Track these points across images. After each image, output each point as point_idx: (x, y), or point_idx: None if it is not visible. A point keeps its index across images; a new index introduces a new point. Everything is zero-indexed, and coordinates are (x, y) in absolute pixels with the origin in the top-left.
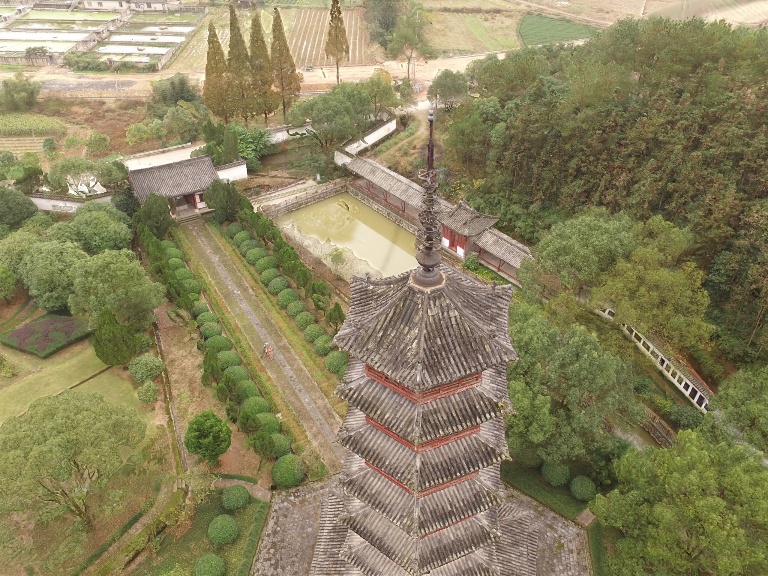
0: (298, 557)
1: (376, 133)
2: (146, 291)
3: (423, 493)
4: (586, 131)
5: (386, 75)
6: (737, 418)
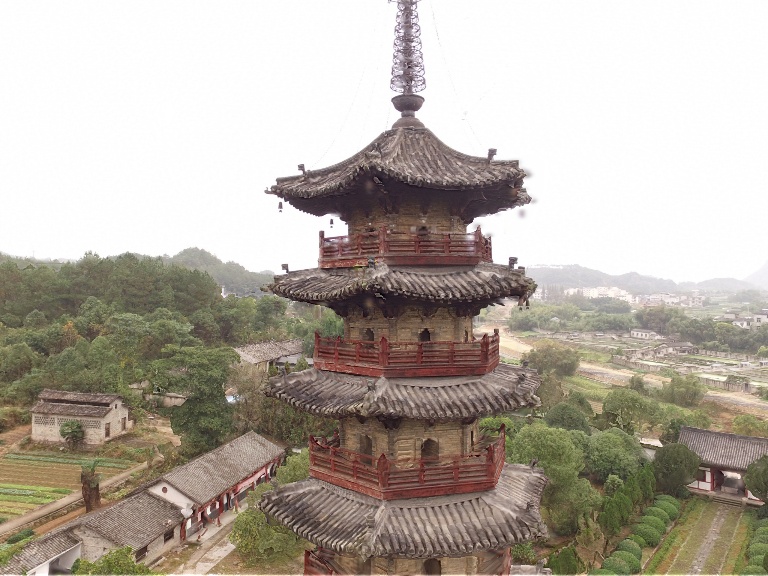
0: None
1: None
2: (563, 473)
3: (315, 467)
4: None
5: None
6: None
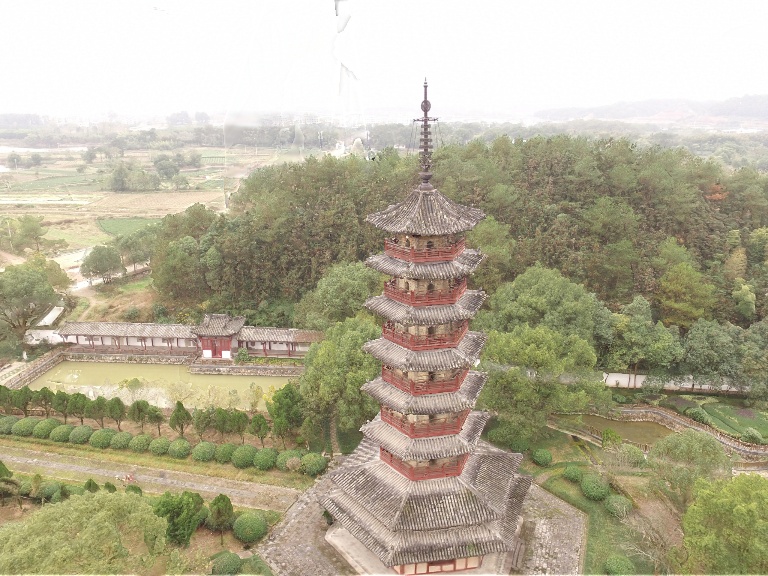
0: (320, 567)
1: (52, 312)
2: None
3: None
4: (282, 235)
5: (43, 257)
6: (500, 324)
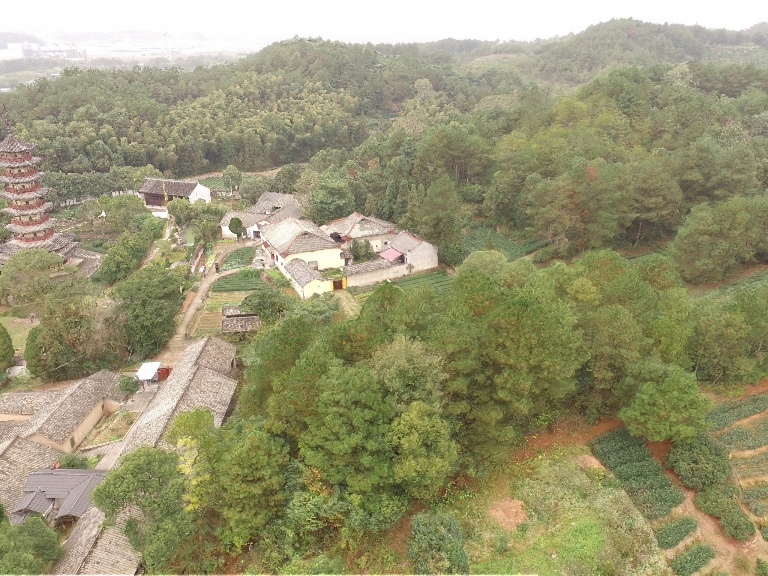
0: None
1: None
2: None
3: None
4: None
5: None
6: None
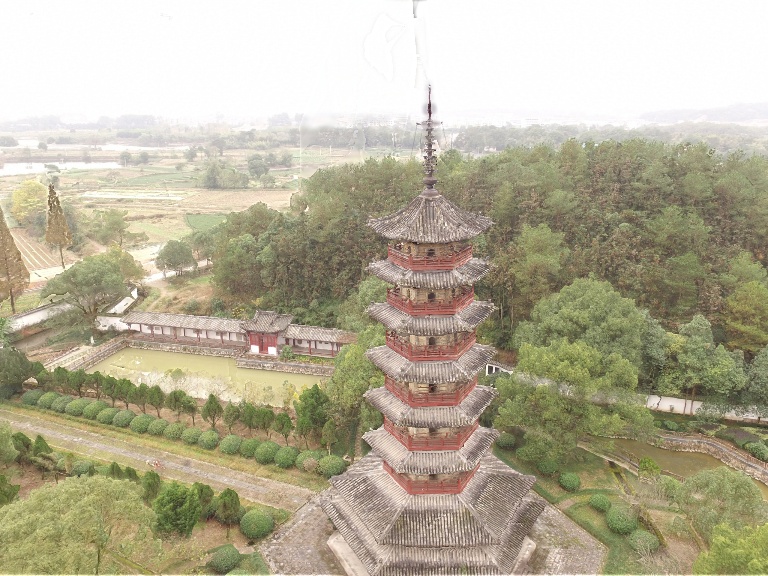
0: (316, 571)
1: (125, 301)
2: None
3: (459, 354)
4: (335, 236)
5: (120, 249)
6: (539, 337)
